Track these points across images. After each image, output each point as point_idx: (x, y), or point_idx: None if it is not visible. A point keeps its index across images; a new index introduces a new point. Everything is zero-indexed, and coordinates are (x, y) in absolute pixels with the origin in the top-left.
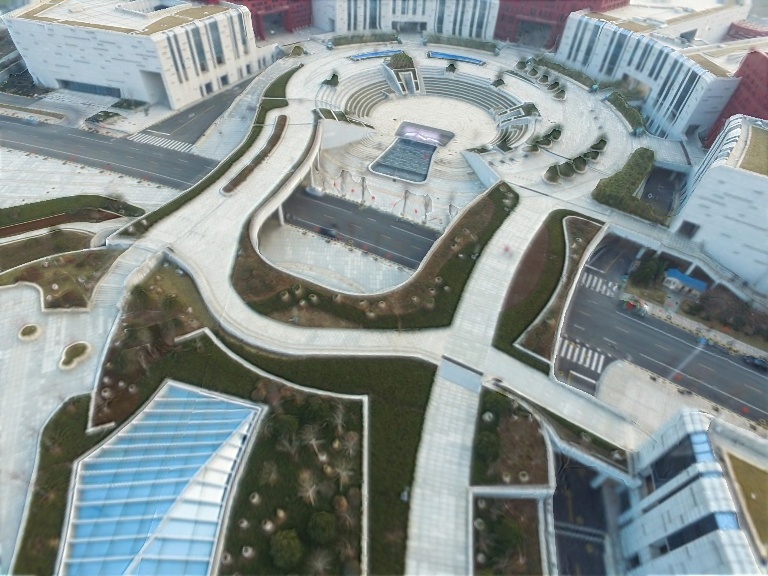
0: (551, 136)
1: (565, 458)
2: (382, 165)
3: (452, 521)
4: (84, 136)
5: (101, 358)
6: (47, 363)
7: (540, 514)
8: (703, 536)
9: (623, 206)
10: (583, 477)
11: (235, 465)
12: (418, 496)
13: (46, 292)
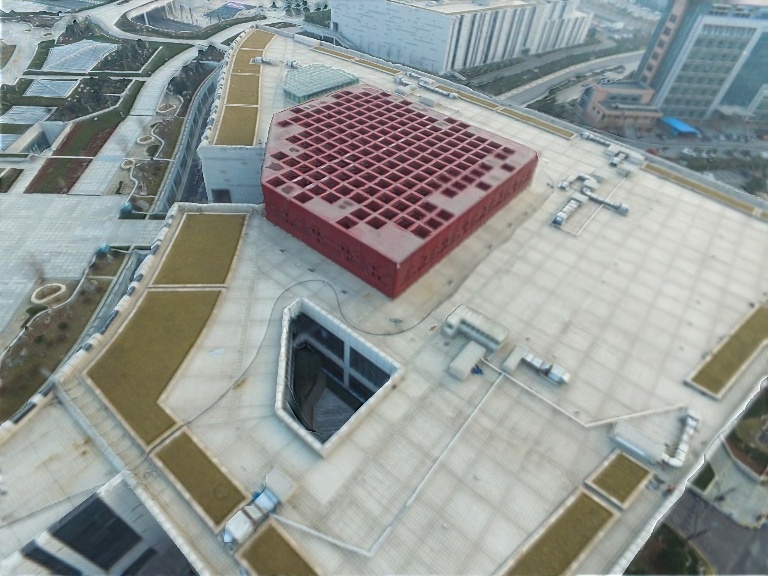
0: (302, 4)
1: None
2: None
3: None
4: None
5: (59, 35)
6: None
7: (215, 69)
8: None
9: (313, 21)
10: None
11: None
12: None
13: (33, 24)
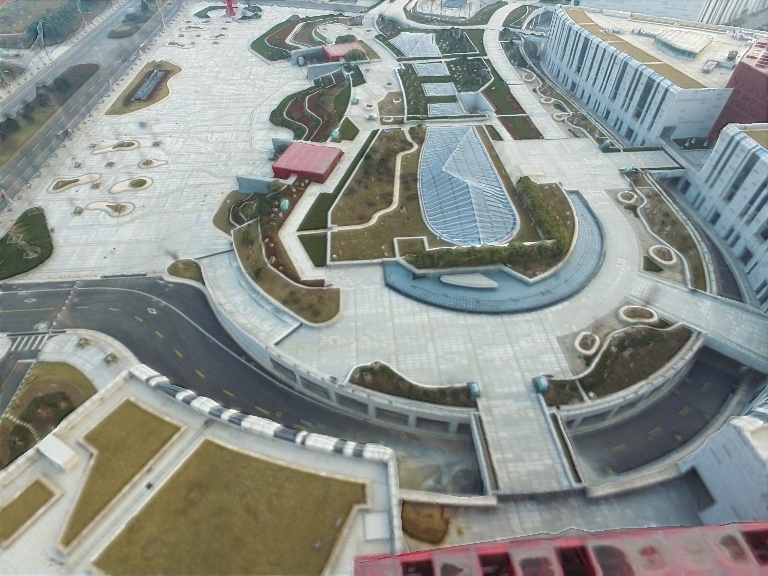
0: None
1: (527, 40)
2: (444, 6)
3: (495, 44)
4: (305, 3)
5: None
6: (362, 33)
7: None
8: (556, 21)
9: (551, 1)
10: (534, 53)
11: (433, 39)
12: (485, 42)
13: (346, 24)
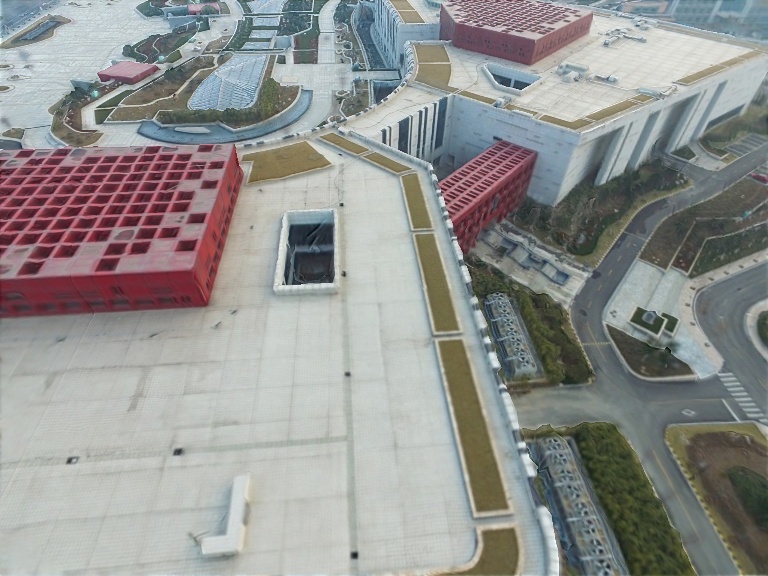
0: None
1: (363, 5)
2: None
3: None
4: None
5: None
6: None
7: None
8: None
9: None
10: None
11: (283, 2)
12: (326, 5)
13: None
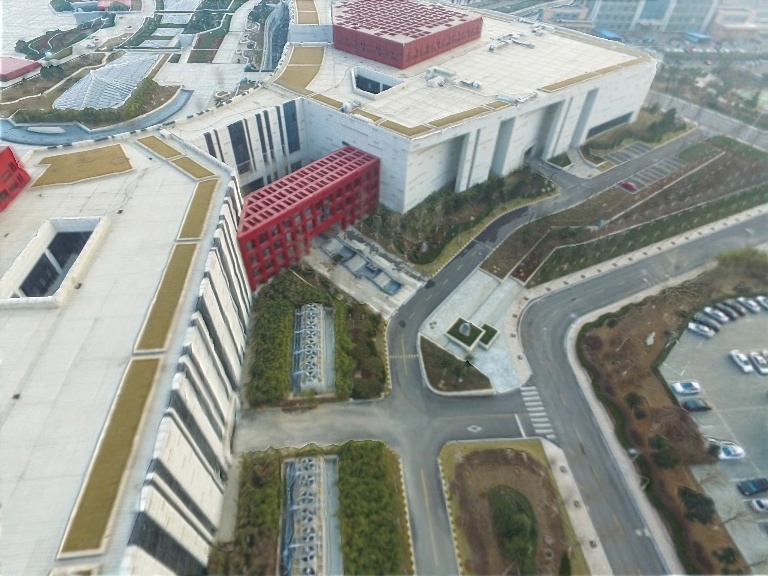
0: None
1: (285, 5)
2: None
3: None
4: None
5: None
6: None
7: (275, 9)
8: None
9: None
10: None
11: (202, 0)
12: (245, 4)
13: None
